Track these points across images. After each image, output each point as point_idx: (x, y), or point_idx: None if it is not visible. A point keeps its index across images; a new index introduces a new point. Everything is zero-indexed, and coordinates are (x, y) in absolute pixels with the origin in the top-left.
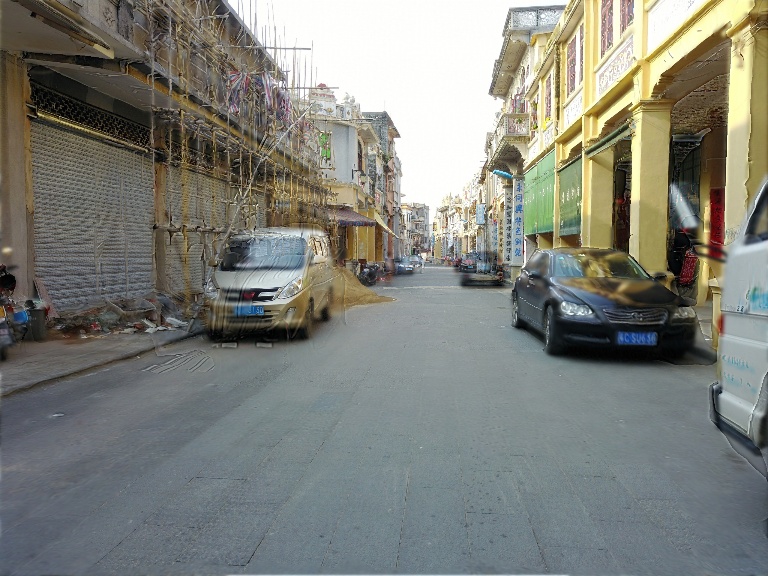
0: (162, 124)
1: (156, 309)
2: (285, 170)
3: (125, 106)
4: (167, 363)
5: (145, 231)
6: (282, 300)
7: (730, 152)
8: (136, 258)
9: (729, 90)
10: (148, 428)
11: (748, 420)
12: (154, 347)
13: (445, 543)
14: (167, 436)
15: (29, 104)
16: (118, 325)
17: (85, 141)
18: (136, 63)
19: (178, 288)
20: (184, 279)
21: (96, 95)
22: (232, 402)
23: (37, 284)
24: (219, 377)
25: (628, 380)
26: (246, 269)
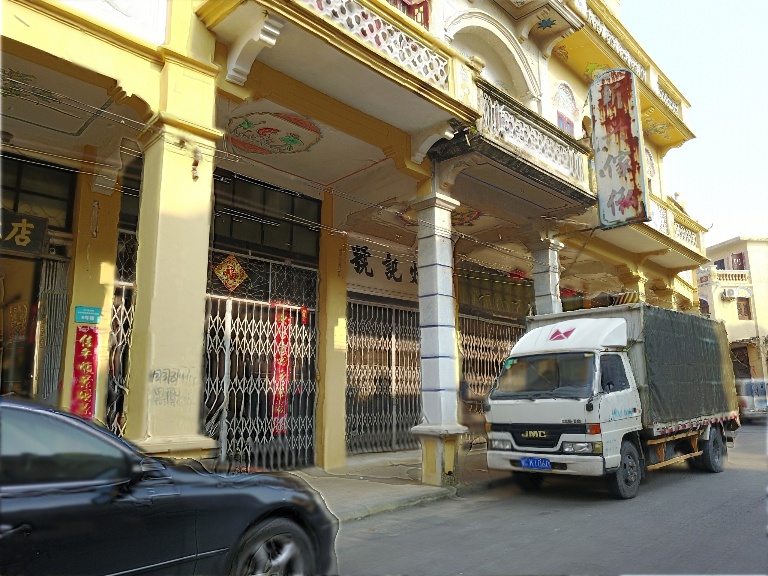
0: None
1: None
2: None
3: None
4: None
5: None
6: None
7: (169, 268)
8: None
9: (167, 188)
10: None
11: (619, 461)
12: None
13: (763, 509)
14: None
15: None
16: None
17: None
18: None
19: None
20: None
21: None
22: None
23: None
24: None
25: (412, 554)
26: None
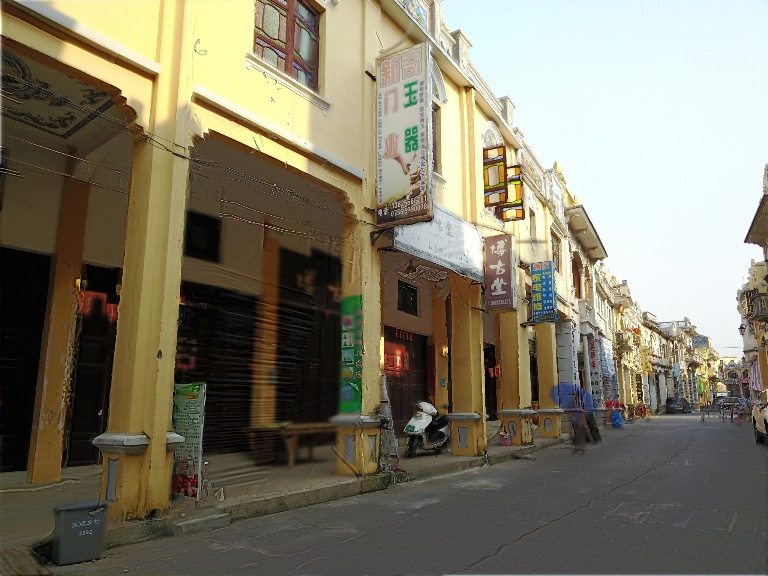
0: None
1: None
2: None
3: None
4: None
5: None
6: None
7: None
8: None
9: None
10: None
11: None
12: None
13: None
14: None
15: None
16: None
17: None
18: None
19: None
20: None
21: None
22: None
23: None
24: None
25: None
26: None
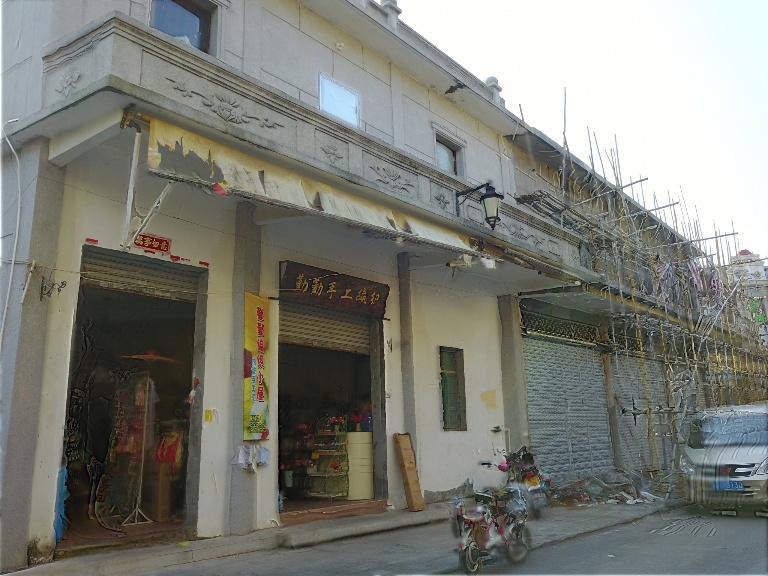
0: (605, 321)
1: (630, 483)
2: (725, 345)
3: (578, 313)
4: (664, 529)
5: (600, 414)
6: (761, 476)
7: None
8: (596, 438)
9: None
10: (689, 570)
11: None
12: (643, 516)
13: None
14: (710, 575)
15: (522, 326)
16: (602, 496)
17: (554, 345)
18: (594, 283)
19: (632, 465)
20: (635, 457)
21: (558, 309)
22: (750, 560)
23: (534, 461)
24: (723, 542)
25: None
26: (715, 446)
